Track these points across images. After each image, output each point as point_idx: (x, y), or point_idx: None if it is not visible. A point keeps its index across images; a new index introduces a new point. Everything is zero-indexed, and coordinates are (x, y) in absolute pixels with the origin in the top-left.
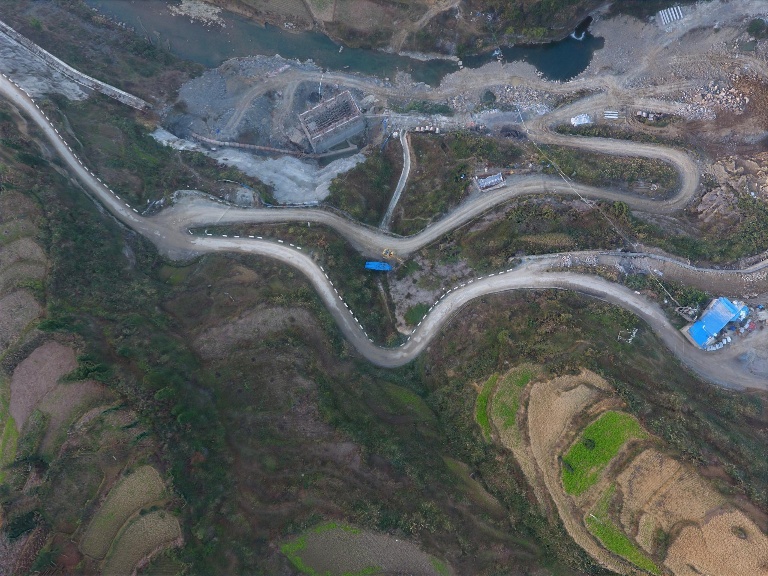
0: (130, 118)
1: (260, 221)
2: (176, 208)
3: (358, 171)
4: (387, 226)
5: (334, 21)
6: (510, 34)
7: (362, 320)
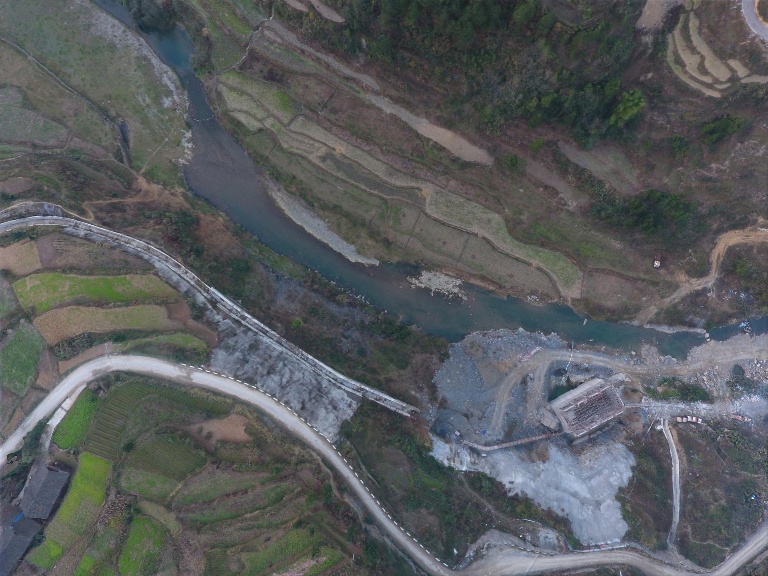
0: (408, 435)
1: (567, 567)
2: (486, 560)
3: (638, 484)
4: (673, 544)
5: (582, 298)
6: (762, 311)
7: None
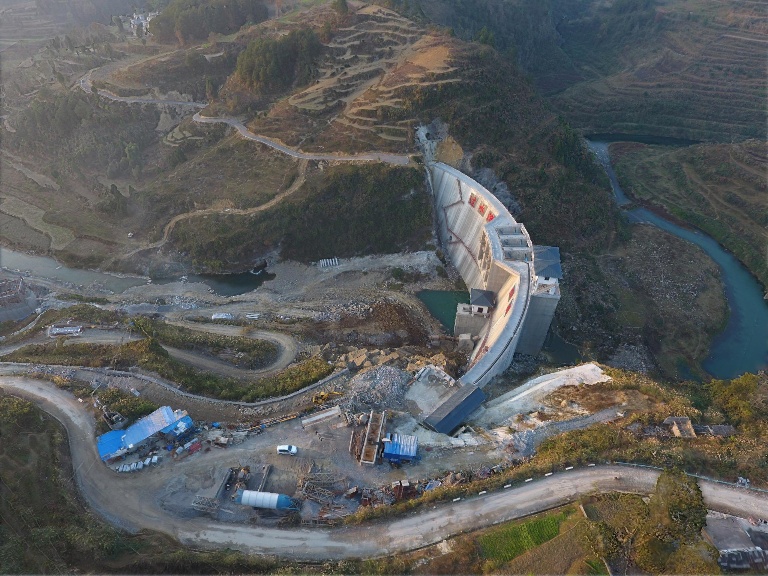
0: None
1: None
2: None
3: None
4: None
5: (63, 250)
6: (195, 264)
7: None
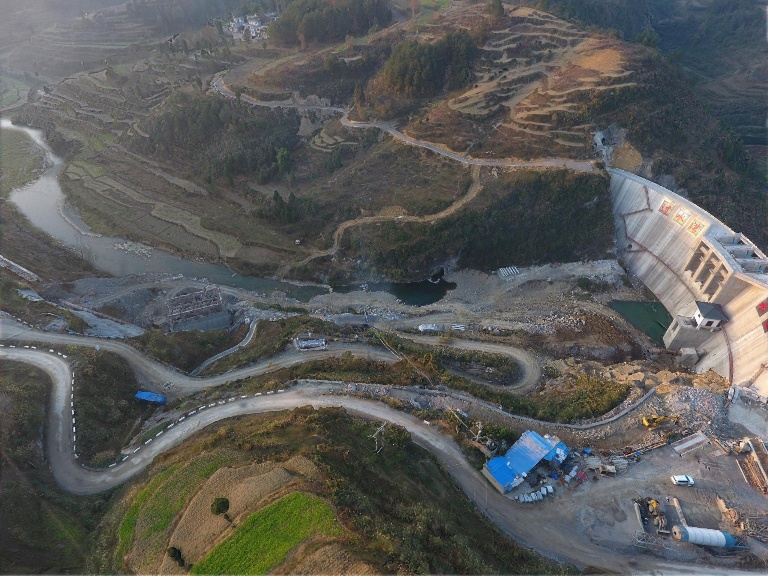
0: None
1: (52, 343)
2: None
3: (190, 332)
4: None
5: (235, 257)
6: (374, 273)
7: (81, 431)
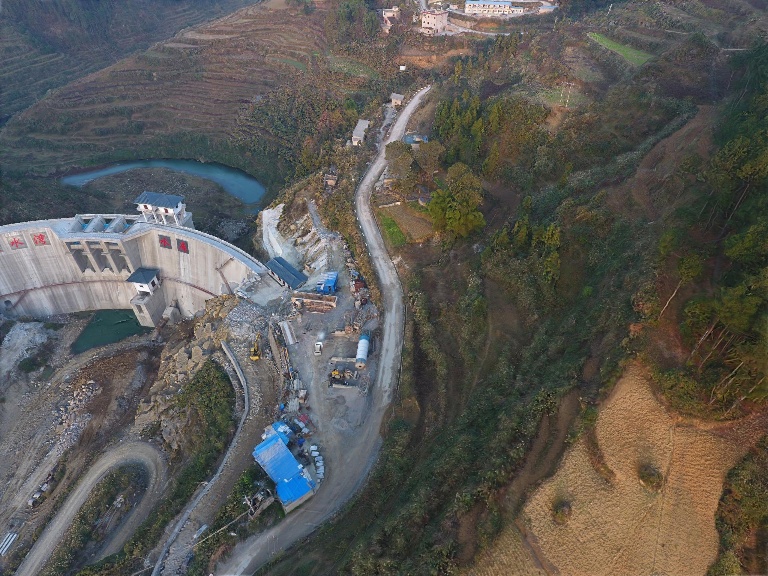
0: None
1: None
2: None
3: None
4: None
5: None
6: None
7: None
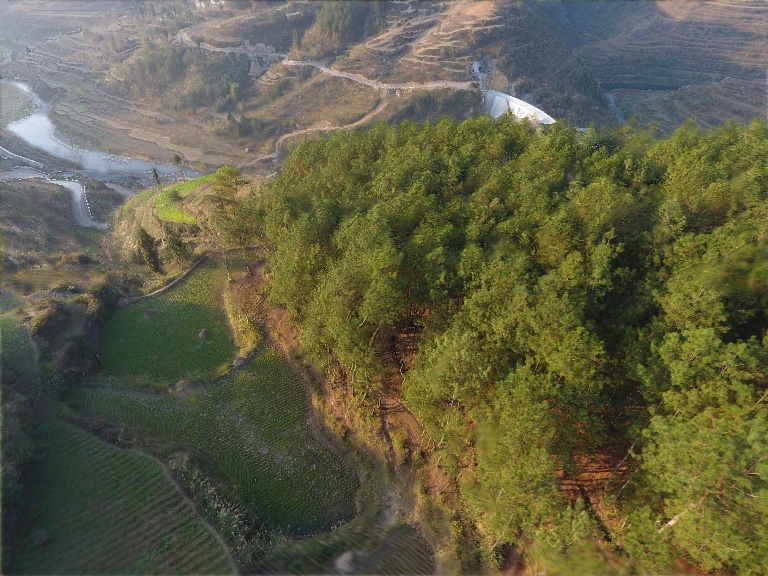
0: None
1: None
2: (10, 172)
3: None
4: None
5: (197, 161)
6: None
7: (93, 208)
